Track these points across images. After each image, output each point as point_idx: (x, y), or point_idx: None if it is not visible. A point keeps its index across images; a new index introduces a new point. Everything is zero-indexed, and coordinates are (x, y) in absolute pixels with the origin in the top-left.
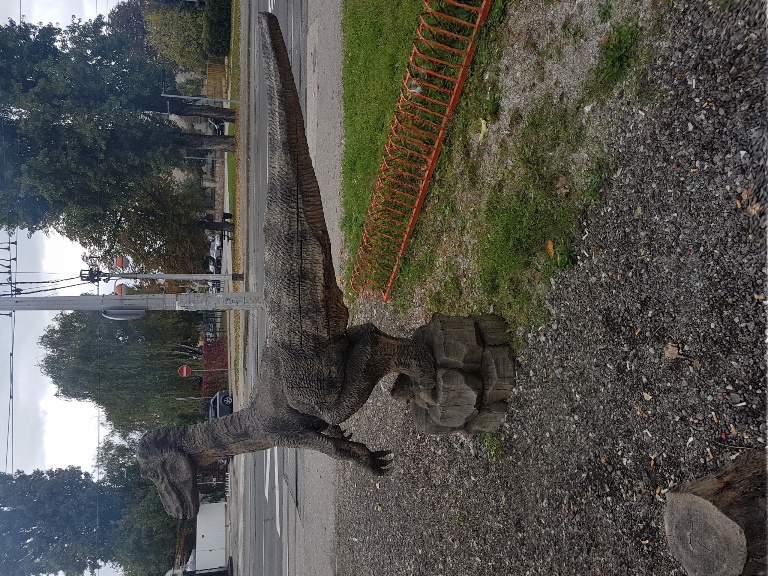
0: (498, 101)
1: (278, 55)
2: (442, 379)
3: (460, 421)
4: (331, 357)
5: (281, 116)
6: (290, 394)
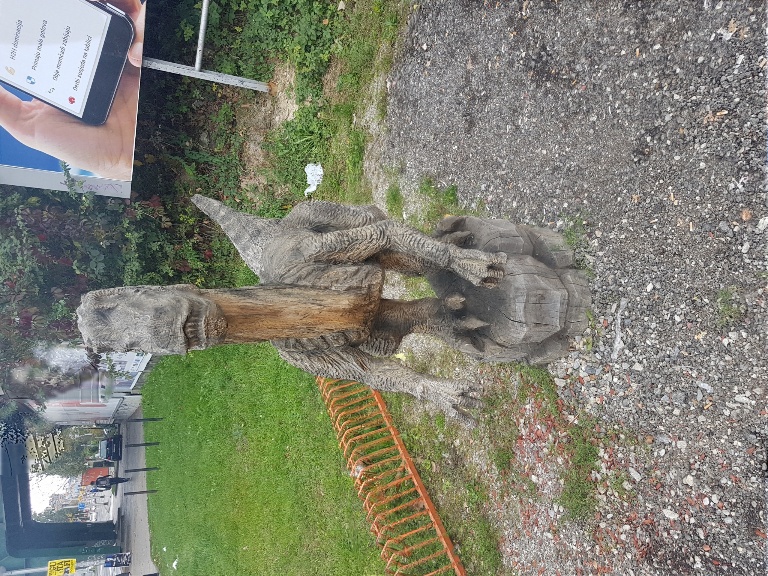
0: None
1: None
2: None
3: (509, 225)
4: None
5: None
6: None
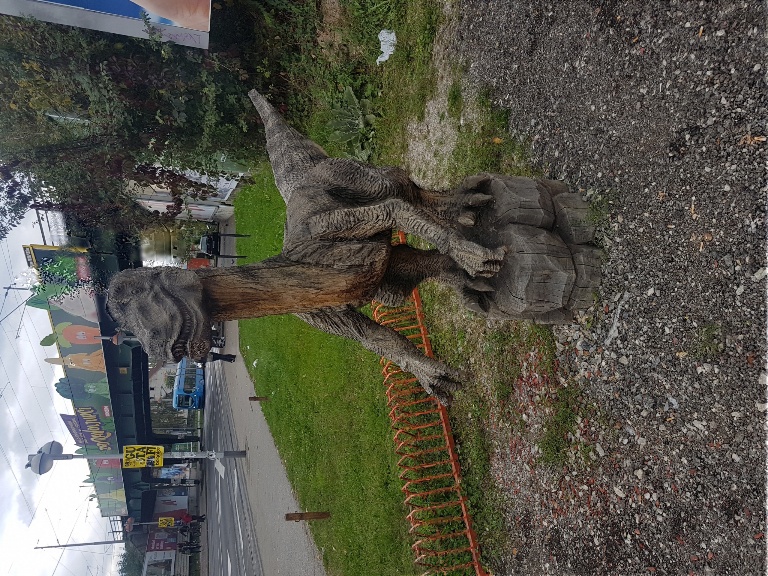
0: None
1: None
2: None
3: (534, 193)
4: None
5: None
6: None
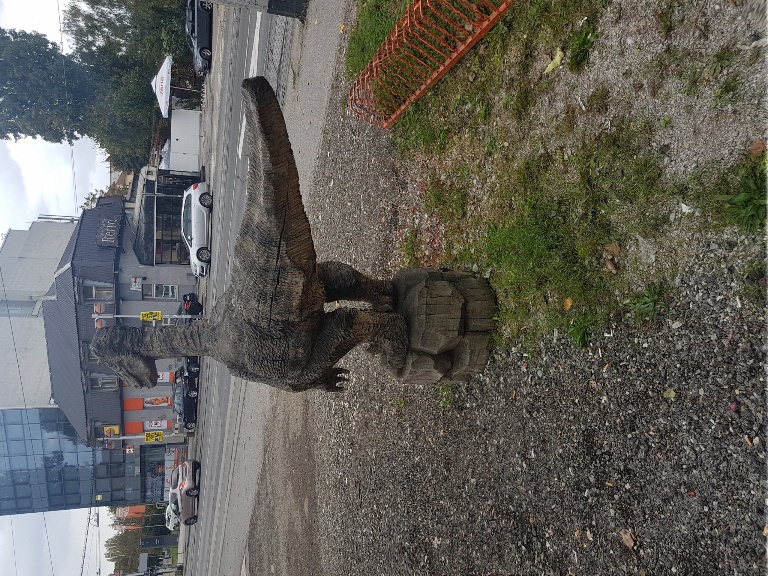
0: (589, 48)
1: (270, 136)
2: (411, 365)
3: None
4: (300, 338)
5: (267, 189)
6: (251, 369)
